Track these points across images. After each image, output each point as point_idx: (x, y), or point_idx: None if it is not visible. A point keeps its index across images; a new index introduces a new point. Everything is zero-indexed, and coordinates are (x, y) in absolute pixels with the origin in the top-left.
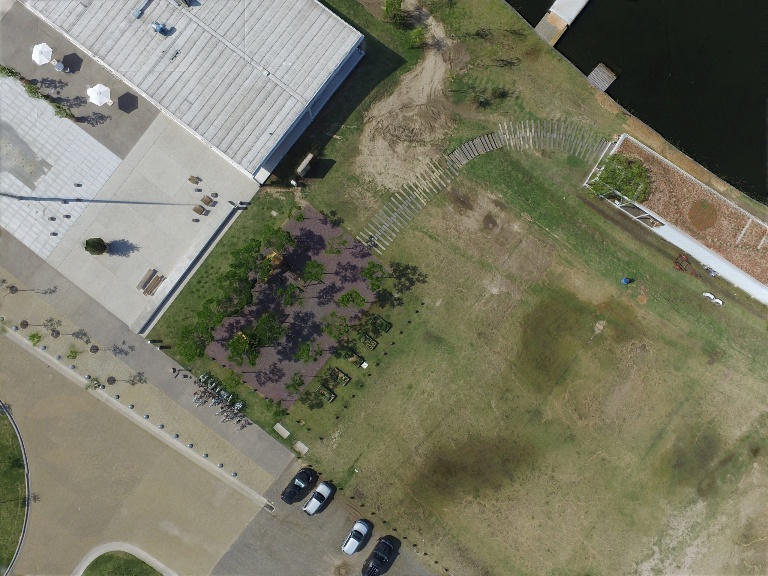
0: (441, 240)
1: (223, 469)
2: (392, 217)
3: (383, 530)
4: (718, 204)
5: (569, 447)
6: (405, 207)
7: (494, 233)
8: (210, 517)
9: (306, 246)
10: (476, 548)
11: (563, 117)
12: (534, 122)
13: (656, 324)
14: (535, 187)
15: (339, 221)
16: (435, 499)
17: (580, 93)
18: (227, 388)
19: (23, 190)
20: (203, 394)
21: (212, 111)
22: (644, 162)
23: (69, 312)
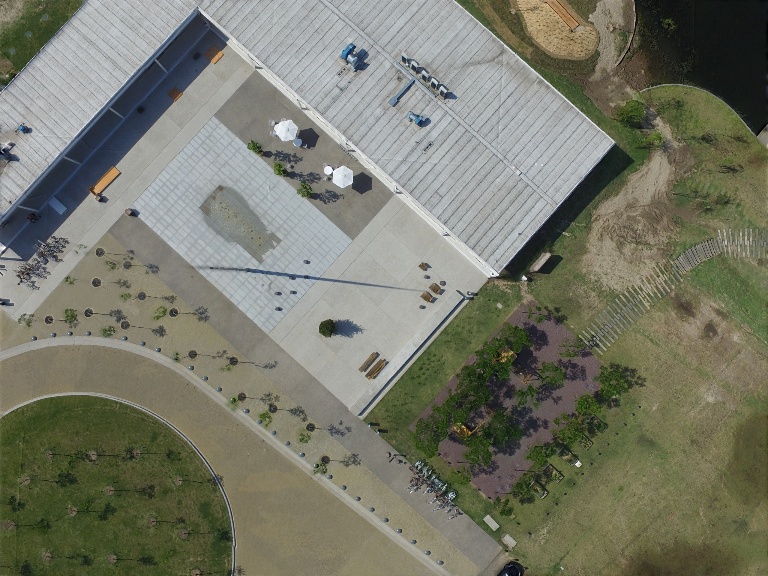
0: (662, 345)
1: (430, 556)
2: (615, 318)
3: None
4: None
5: None
6: (629, 309)
7: (714, 342)
8: None
9: None
10: None
11: None
12: (752, 231)
13: None
14: (752, 297)
15: (563, 318)
16: None
17: None
18: (440, 476)
19: (250, 262)
20: (417, 481)
21: (462, 206)
22: None
23: (288, 388)
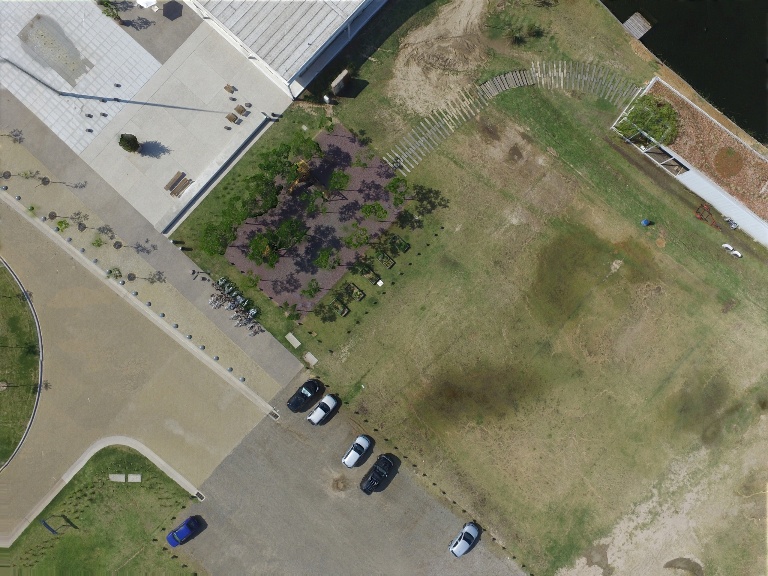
0: (466, 167)
1: (232, 373)
2: (419, 141)
3: (384, 447)
4: (744, 153)
5: (576, 382)
6: (433, 132)
7: (519, 165)
8: (215, 419)
9: (333, 162)
10: (475, 474)
11: (596, 60)
12: (567, 63)
13: (673, 268)
14: (563, 125)
15: (367, 140)
16: (438, 421)
17: (614, 39)
18: (243, 294)
19: (64, 86)
20: (219, 297)
21: (254, 18)
22: (673, 106)
23: (97, 207)
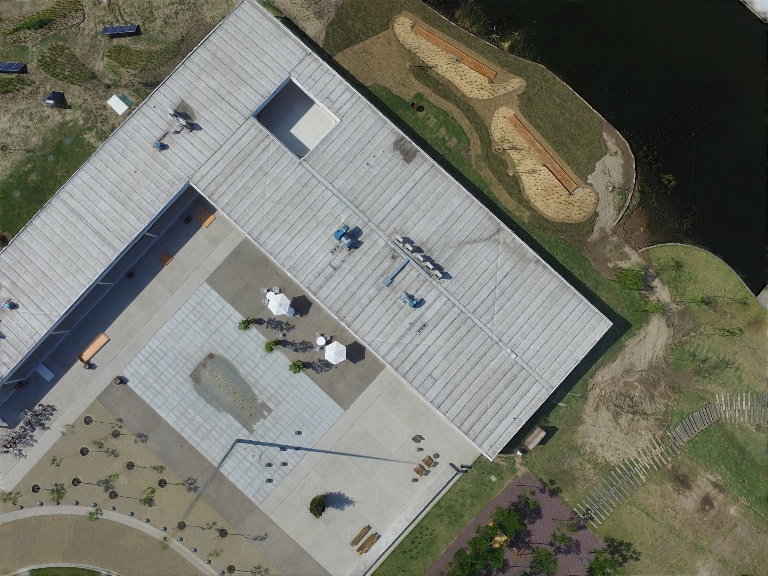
0: (658, 519)
1: None
2: (611, 491)
3: None
4: None
5: None
6: (624, 482)
7: (710, 515)
8: None
9: (523, 514)
10: None
11: None
12: (751, 395)
13: None
14: (749, 465)
15: (557, 491)
16: None
17: None
18: None
19: (241, 432)
20: None
21: (456, 389)
22: None
23: (278, 561)
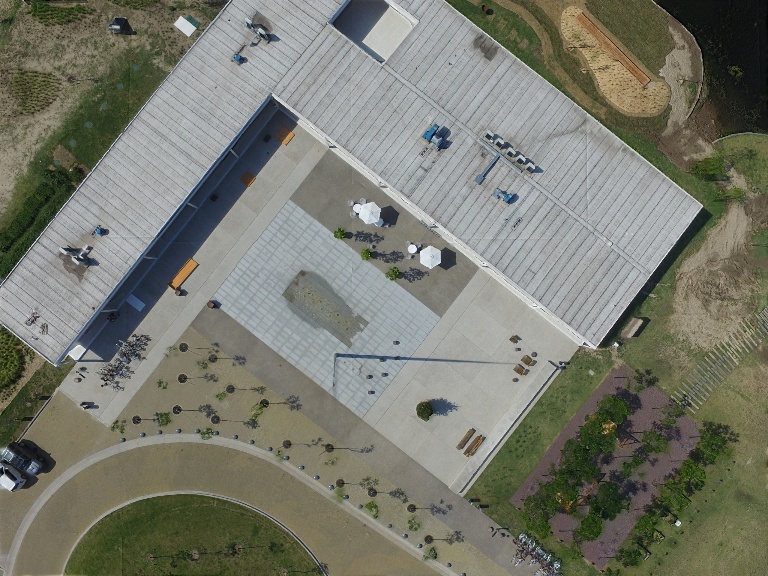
0: (752, 399)
1: None
2: (705, 376)
3: None
4: None
5: None
6: (718, 366)
7: None
8: None
9: None
10: None
11: None
12: None
13: None
14: None
15: (654, 380)
16: None
17: None
18: (543, 546)
19: (339, 347)
20: (520, 553)
21: (555, 281)
22: None
23: (386, 471)
